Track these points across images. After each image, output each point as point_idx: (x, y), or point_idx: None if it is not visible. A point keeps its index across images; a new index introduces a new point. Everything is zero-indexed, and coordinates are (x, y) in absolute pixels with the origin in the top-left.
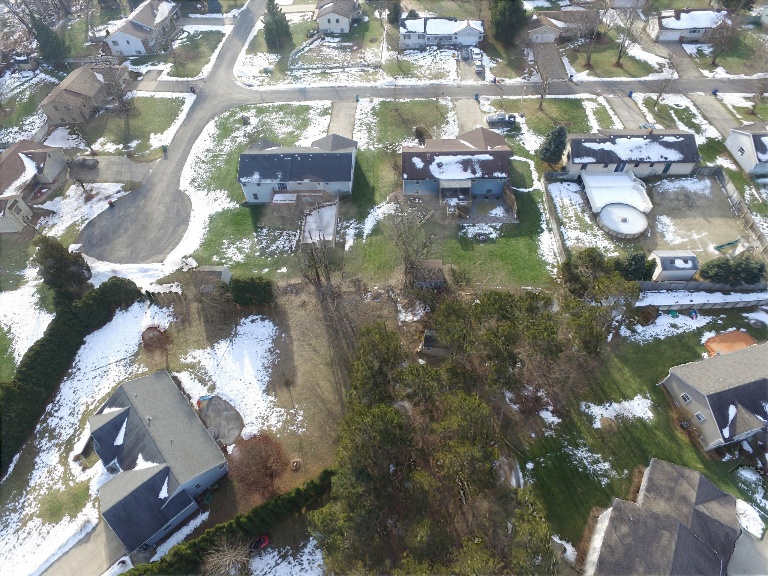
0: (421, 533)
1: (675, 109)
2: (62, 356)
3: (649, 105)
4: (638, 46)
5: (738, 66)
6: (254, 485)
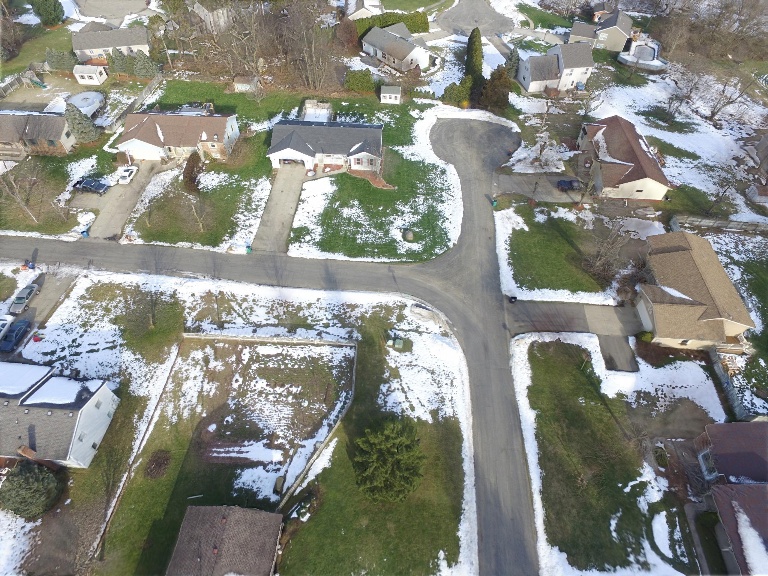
0: None
1: None
2: None
3: None
4: None
5: None
6: (352, 48)
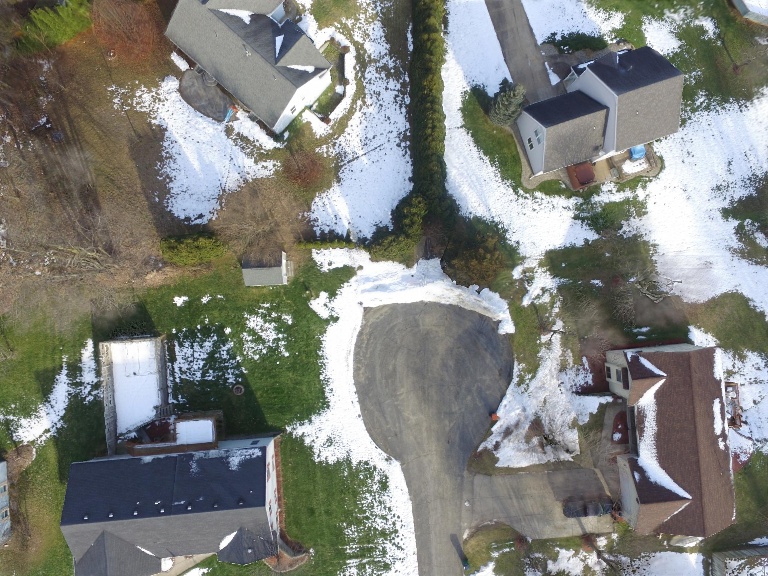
0: None
1: None
2: None
3: None
4: None
5: None
6: None
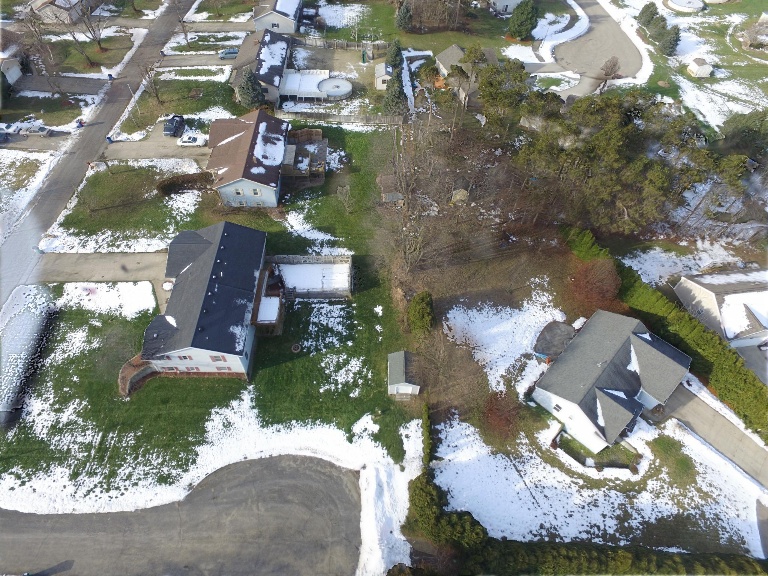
0: (658, 124)
1: (198, 41)
2: None
3: (185, 49)
4: (106, 22)
5: (147, 4)
6: (597, 305)
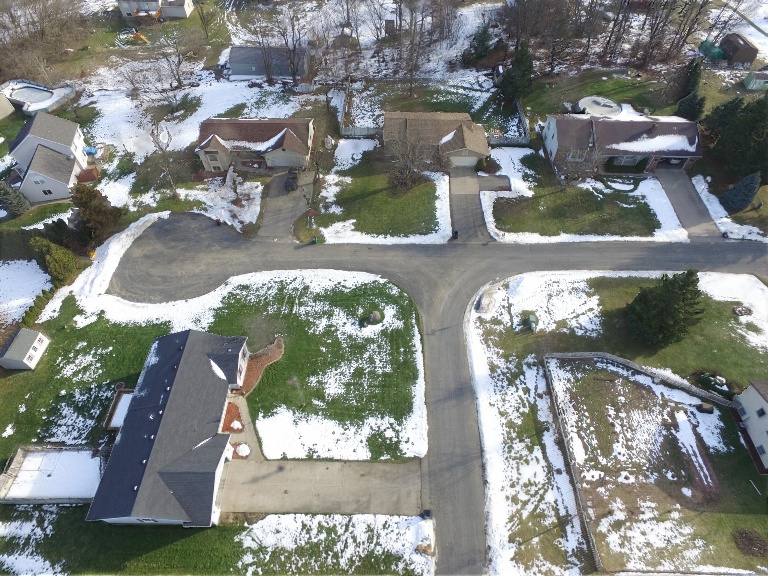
0: None
1: None
2: (4, 250)
3: None
4: None
5: None
6: None
